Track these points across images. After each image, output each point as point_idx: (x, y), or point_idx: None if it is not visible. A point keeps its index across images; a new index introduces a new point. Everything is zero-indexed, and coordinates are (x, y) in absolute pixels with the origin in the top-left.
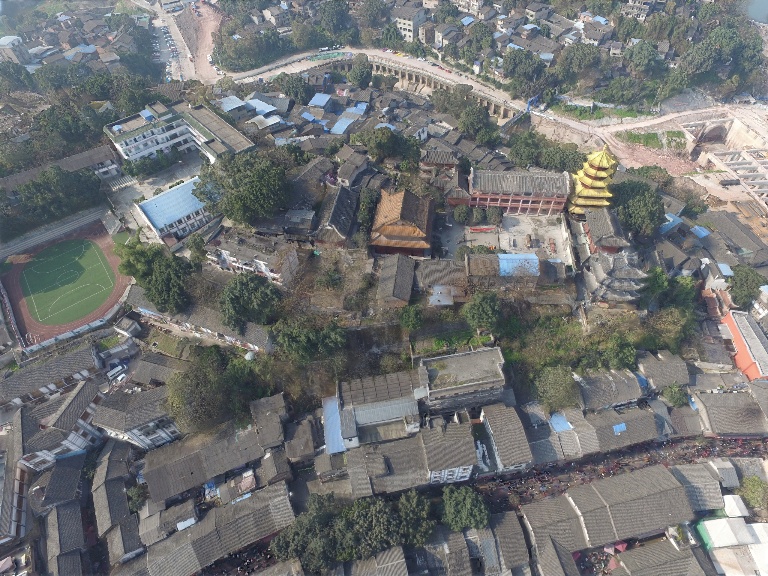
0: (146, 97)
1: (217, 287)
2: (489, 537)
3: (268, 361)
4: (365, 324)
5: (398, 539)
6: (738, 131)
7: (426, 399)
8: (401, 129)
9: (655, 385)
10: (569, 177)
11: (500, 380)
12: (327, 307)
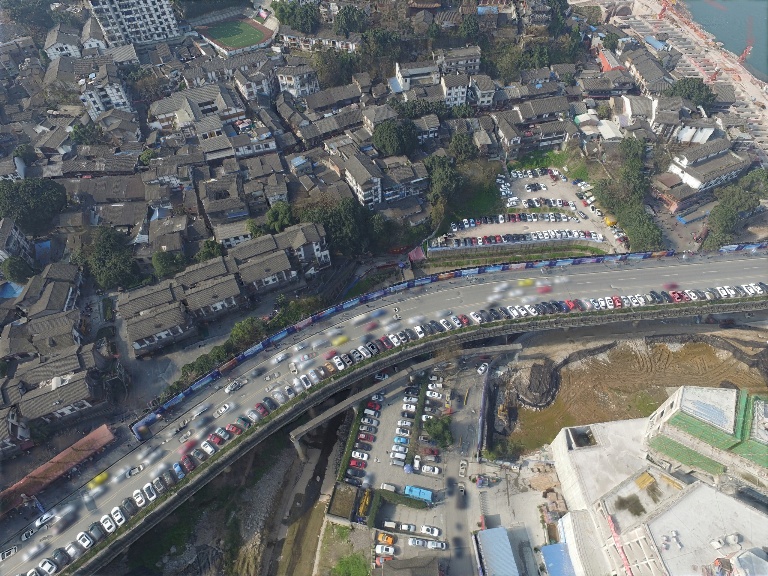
0: None
1: None
2: (475, 118)
3: (362, 49)
4: (409, 37)
5: (433, 109)
6: (637, 9)
7: (442, 66)
8: None
9: (558, 74)
10: None
11: (479, 55)
12: (390, 27)
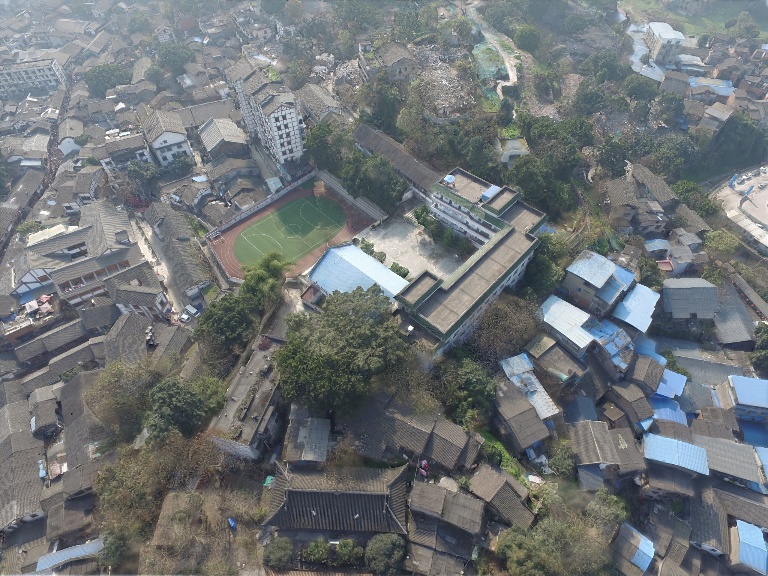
0: (534, 179)
1: (227, 367)
2: None
3: None
4: None
5: None
6: None
7: None
8: None
9: None
10: None
11: None
12: None
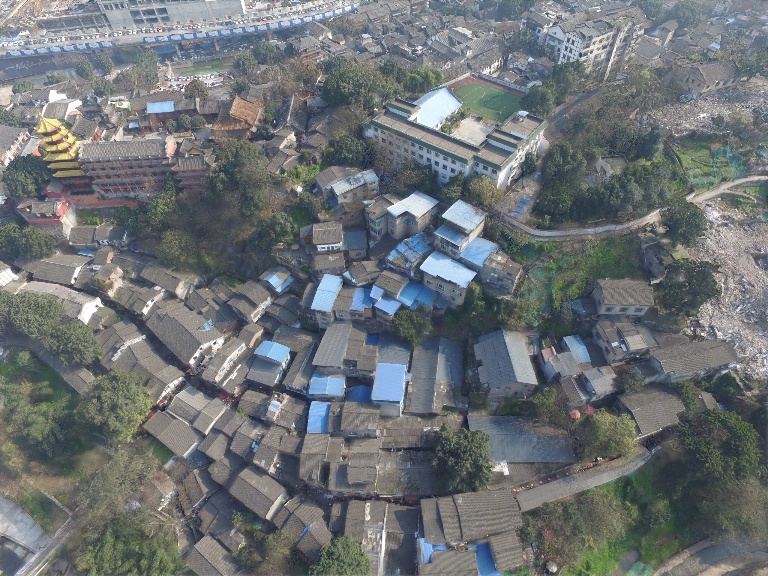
0: None
1: None
2: None
3: None
4: None
5: None
6: None
7: None
8: (249, 376)
9: None
10: (82, 142)
11: None
12: None
